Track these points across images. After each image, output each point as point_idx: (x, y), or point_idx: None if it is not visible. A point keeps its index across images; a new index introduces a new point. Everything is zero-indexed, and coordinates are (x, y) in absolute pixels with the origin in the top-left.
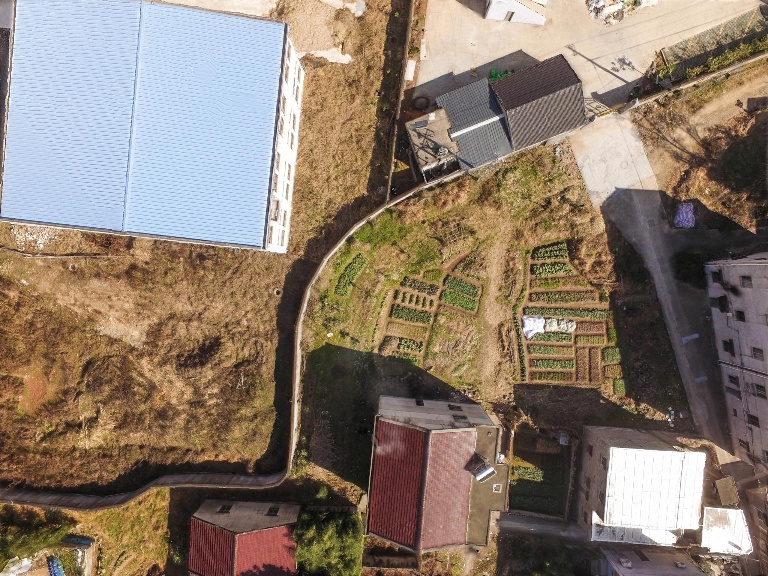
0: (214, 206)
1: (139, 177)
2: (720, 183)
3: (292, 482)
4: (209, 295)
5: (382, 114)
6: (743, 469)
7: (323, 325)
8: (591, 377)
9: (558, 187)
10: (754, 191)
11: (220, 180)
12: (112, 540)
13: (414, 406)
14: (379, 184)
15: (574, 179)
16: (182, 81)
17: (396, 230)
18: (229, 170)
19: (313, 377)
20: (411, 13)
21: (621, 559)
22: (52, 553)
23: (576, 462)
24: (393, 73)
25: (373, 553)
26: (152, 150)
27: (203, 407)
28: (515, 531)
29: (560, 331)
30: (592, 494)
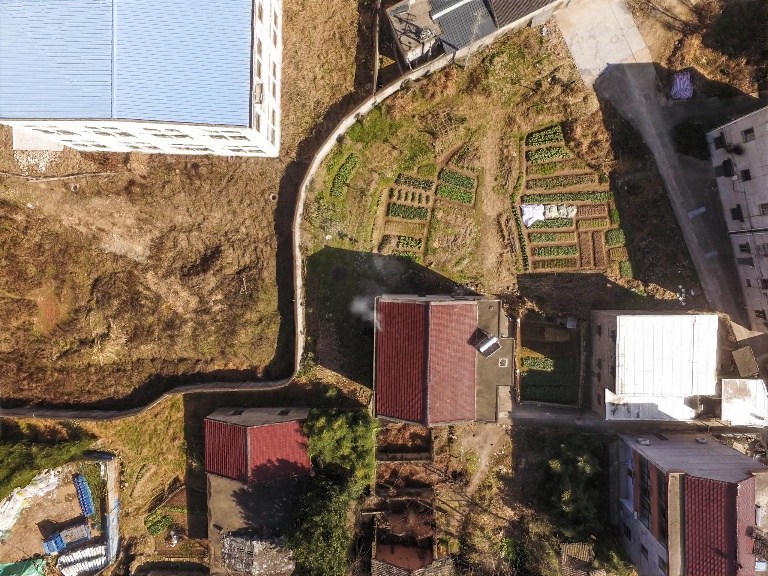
0: (198, 88)
1: (124, 64)
2: (717, 50)
3: (302, 386)
4: (207, 205)
5: (364, 9)
6: (762, 344)
7: (321, 228)
8: (596, 261)
9: (548, 68)
10: (754, 53)
11: (202, 62)
12: (132, 454)
13: (416, 296)
14: (366, 81)
15: (564, 58)
16: None
17: (386, 127)
18: (210, 51)
19: (315, 281)
20: None
21: (638, 438)
22: (76, 470)
23: (586, 347)
24: None
25: (386, 451)
26: (134, 36)
27: (209, 314)
28: (528, 422)
29: (560, 217)
30: (603, 373)
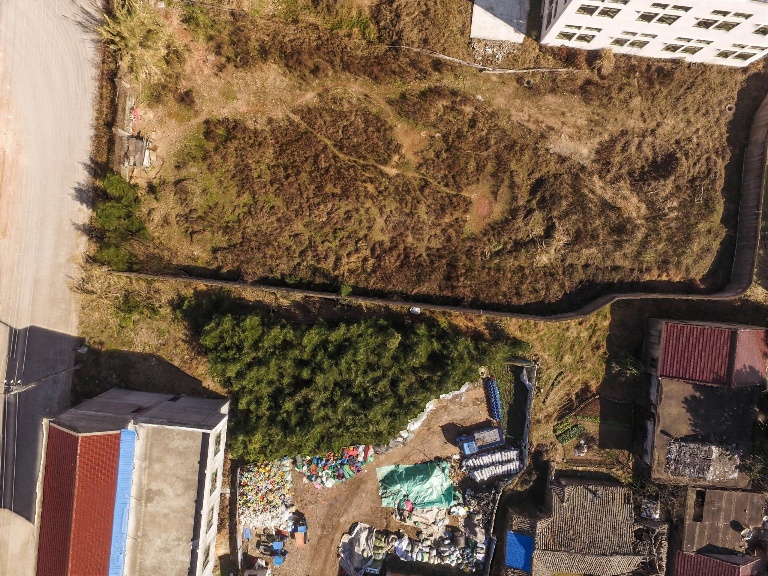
0: None
1: None
2: None
3: (730, 302)
4: (663, 111)
5: None
6: None
7: None
8: None
9: None
10: None
11: None
12: (551, 360)
13: None
14: None
15: None
16: None
17: None
18: None
19: None
20: None
21: None
22: (488, 374)
23: None
24: None
25: None
26: None
27: (663, 220)
28: None
29: None
30: None
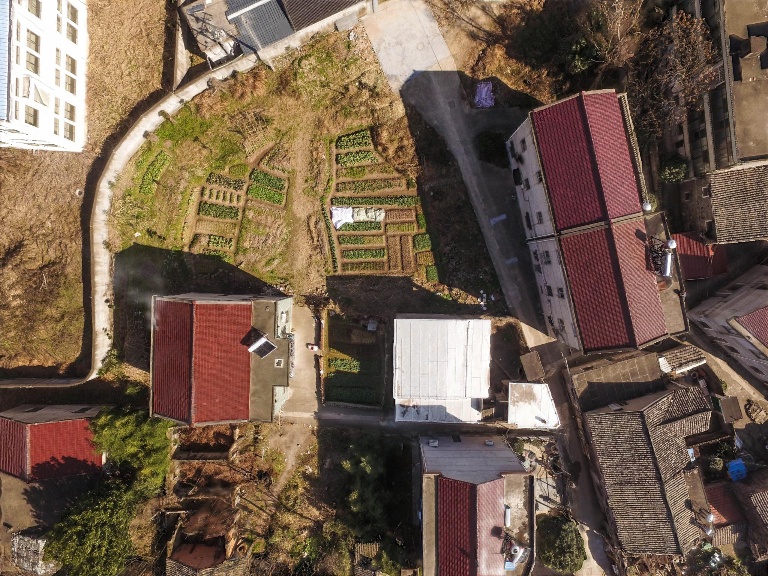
0: None
1: None
2: (520, 61)
3: (109, 384)
4: (11, 199)
5: (171, 7)
6: (559, 349)
7: (130, 225)
8: (403, 265)
9: (355, 72)
10: (552, 65)
11: None
12: None
13: None
14: None
15: (371, 64)
16: None
17: (197, 126)
18: None
19: (124, 278)
20: None
21: (429, 440)
22: None
23: (389, 349)
24: None
25: (190, 450)
26: None
27: (7, 309)
28: (334, 423)
29: (369, 220)
30: None
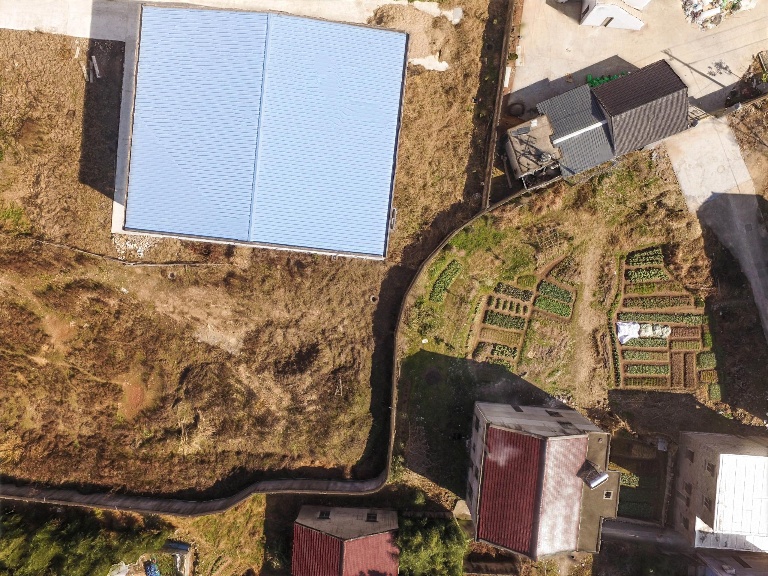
0: (336, 215)
1: (265, 187)
2: None
3: (387, 488)
4: (306, 302)
5: (478, 121)
6: None
7: (418, 331)
8: (686, 382)
9: (654, 192)
10: None
11: (342, 189)
12: (209, 545)
13: (514, 412)
14: (474, 190)
15: (670, 184)
16: (307, 92)
17: (490, 236)
18: (351, 179)
19: (407, 383)
20: (511, 20)
21: (723, 566)
22: (149, 558)
23: (673, 468)
24: (489, 80)
25: (470, 559)
26: (277, 160)
27: (302, 413)
28: (611, 537)
29: (655, 336)
30: (695, 500)
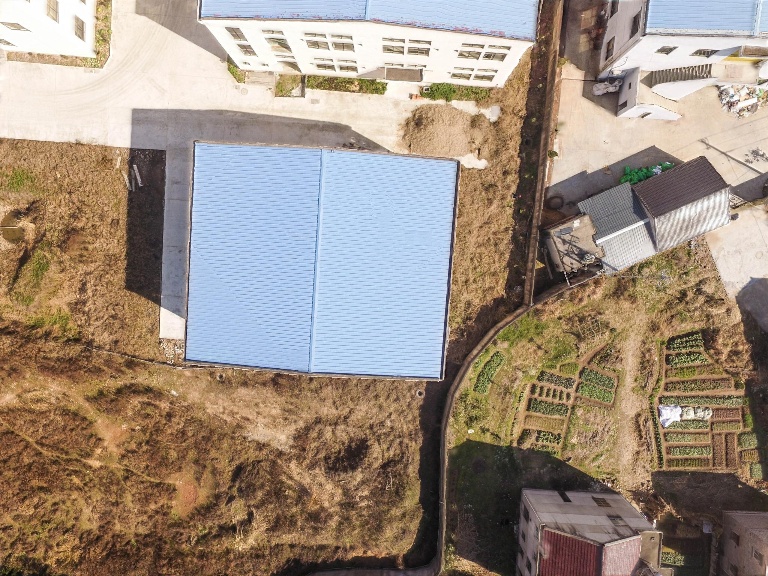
0: (394, 342)
1: (323, 319)
2: None
3: None
4: (354, 399)
5: (519, 216)
6: None
7: (463, 422)
8: (728, 462)
9: (694, 279)
10: None
11: (399, 317)
12: None
13: (563, 503)
14: (516, 284)
15: (709, 271)
16: (362, 224)
17: (532, 327)
18: (407, 306)
19: (455, 472)
20: (551, 120)
21: None
22: None
23: (717, 547)
24: (529, 175)
25: None
26: (335, 292)
27: (354, 509)
28: None
29: (696, 418)
30: None
